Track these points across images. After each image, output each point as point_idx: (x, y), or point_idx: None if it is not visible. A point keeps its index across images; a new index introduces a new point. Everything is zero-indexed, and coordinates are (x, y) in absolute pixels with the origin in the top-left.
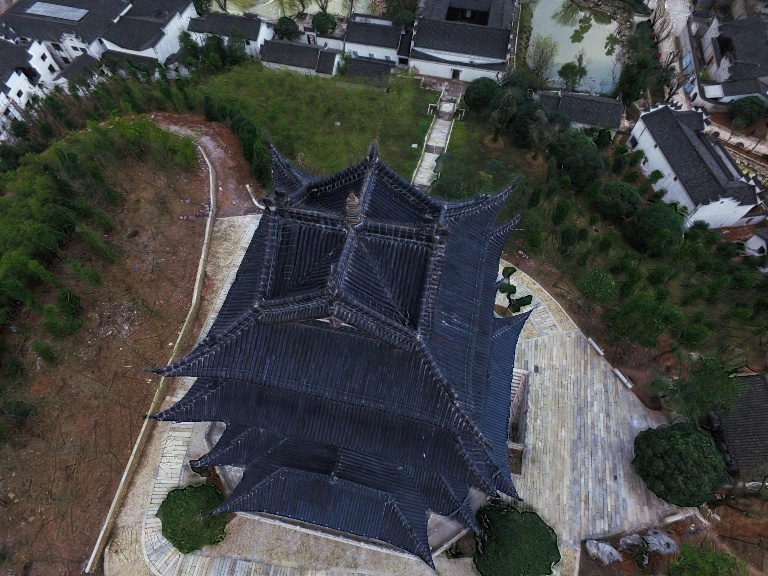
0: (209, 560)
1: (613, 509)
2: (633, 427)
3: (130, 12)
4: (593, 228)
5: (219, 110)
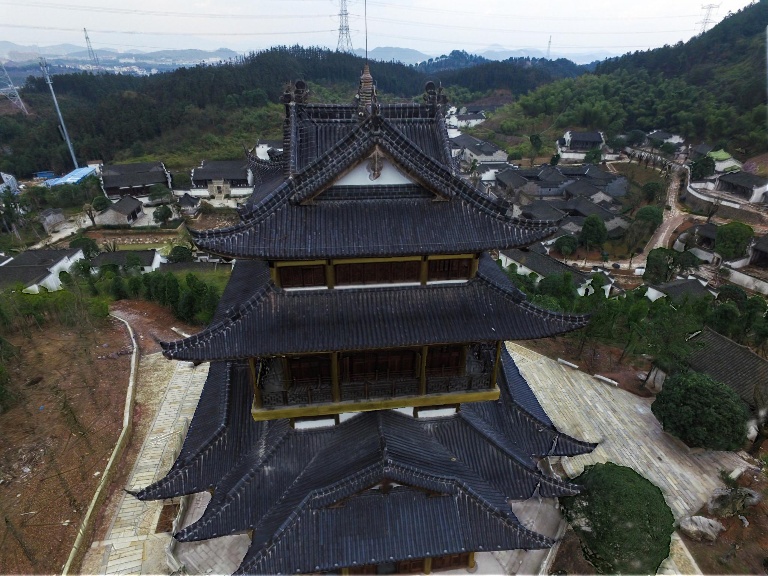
0: None
1: (679, 487)
2: (642, 414)
3: (11, 263)
4: None
5: (131, 282)
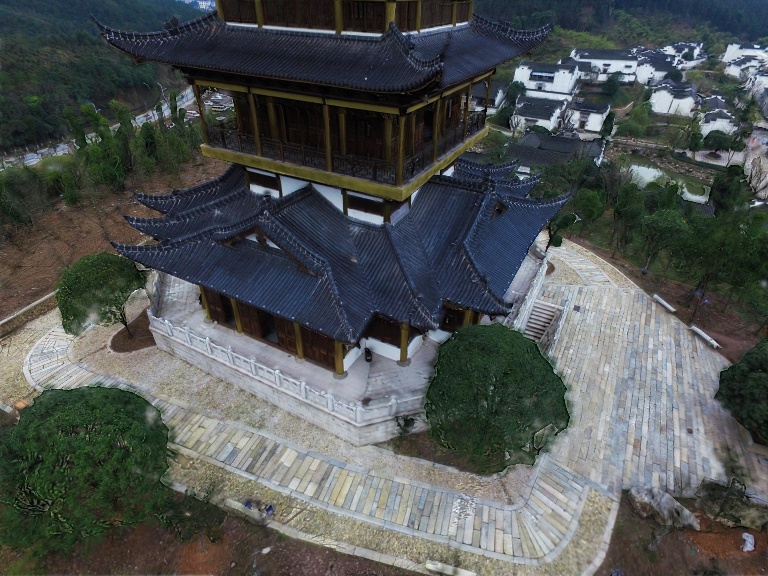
0: (91, 375)
1: (684, 466)
2: None
3: None
4: None
5: None
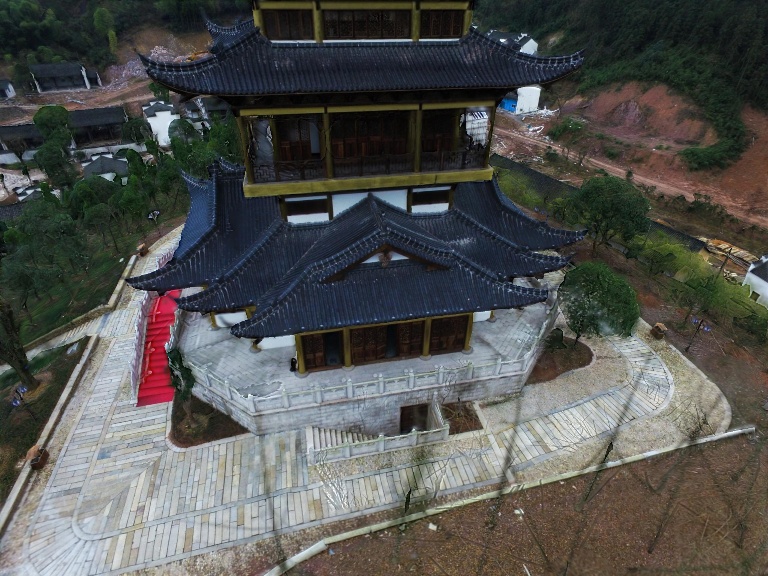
0: (610, 338)
1: None
2: None
3: None
4: (88, 236)
5: None
